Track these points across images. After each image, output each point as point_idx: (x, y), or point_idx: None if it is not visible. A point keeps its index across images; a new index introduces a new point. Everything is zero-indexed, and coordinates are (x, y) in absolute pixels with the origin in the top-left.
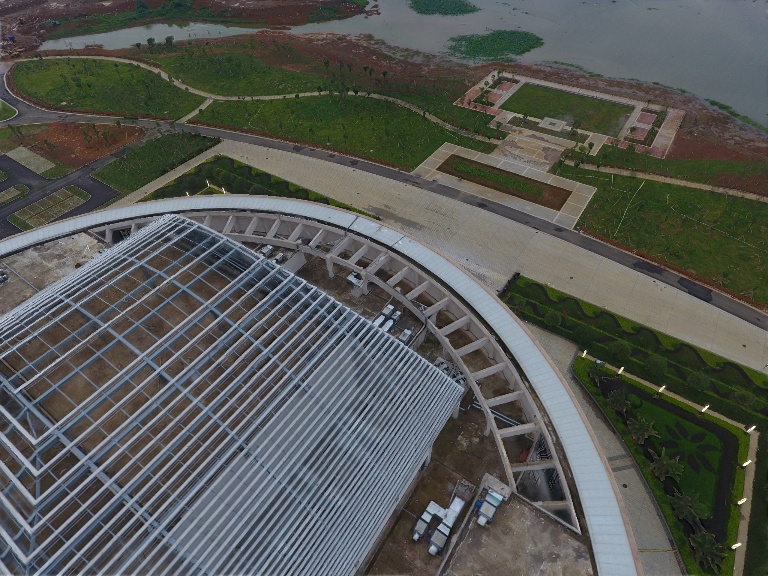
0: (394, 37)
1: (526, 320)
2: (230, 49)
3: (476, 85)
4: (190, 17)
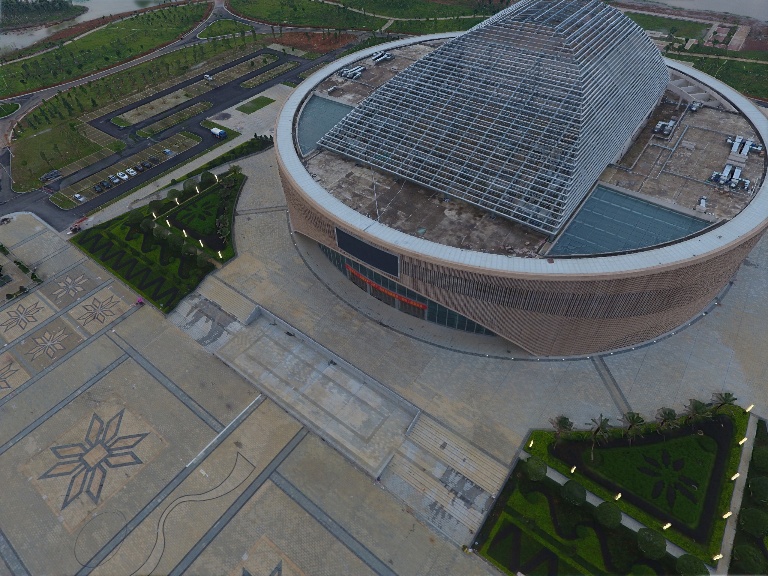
0: None
1: None
2: None
3: None
4: None
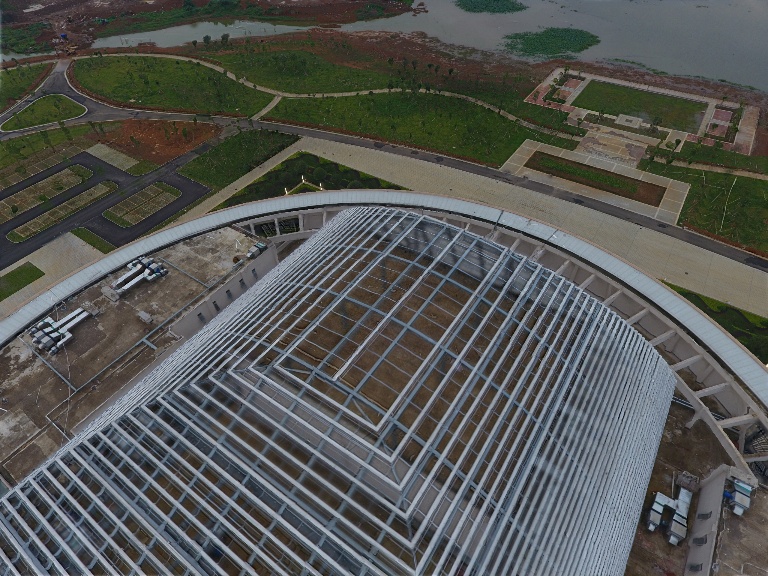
0: (448, 35)
1: None
2: (287, 47)
3: (543, 82)
4: (237, 15)
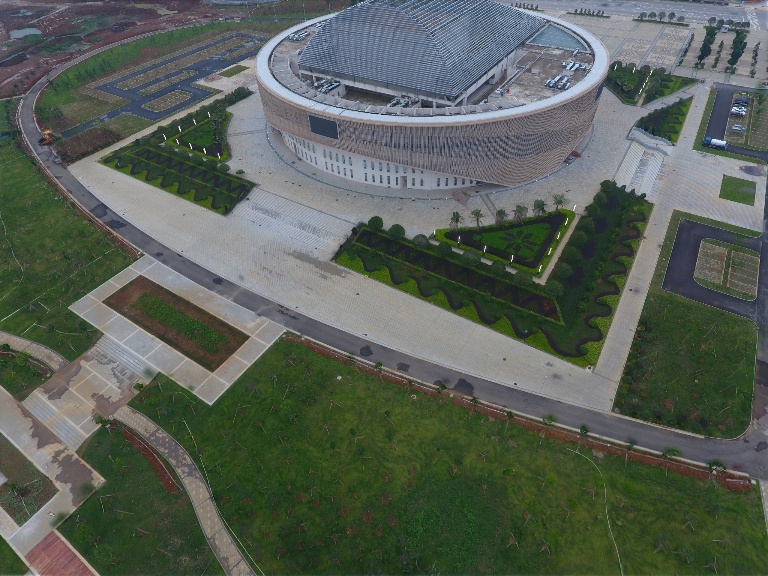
0: None
1: None
2: None
3: None
4: None
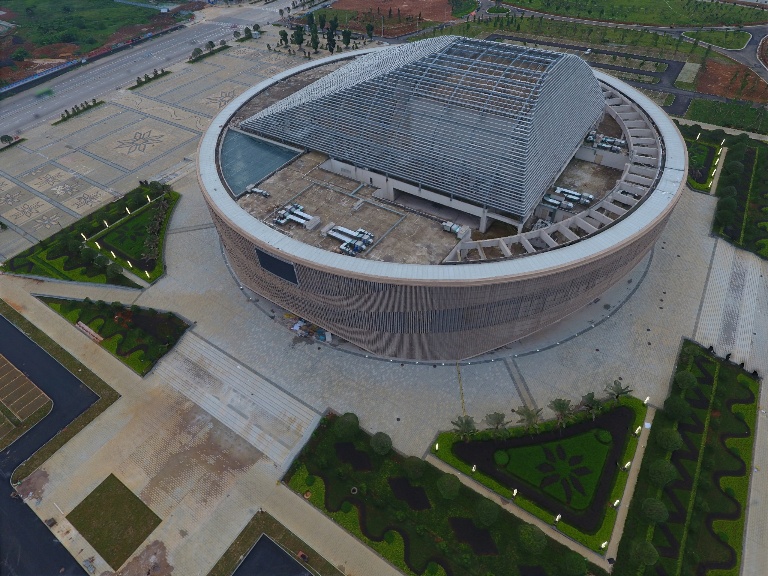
0: None
1: (678, 367)
2: None
3: None
4: None
